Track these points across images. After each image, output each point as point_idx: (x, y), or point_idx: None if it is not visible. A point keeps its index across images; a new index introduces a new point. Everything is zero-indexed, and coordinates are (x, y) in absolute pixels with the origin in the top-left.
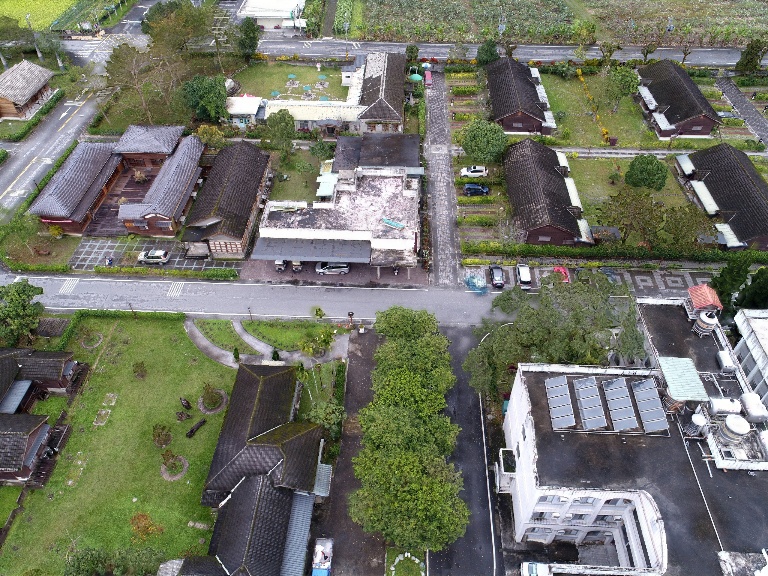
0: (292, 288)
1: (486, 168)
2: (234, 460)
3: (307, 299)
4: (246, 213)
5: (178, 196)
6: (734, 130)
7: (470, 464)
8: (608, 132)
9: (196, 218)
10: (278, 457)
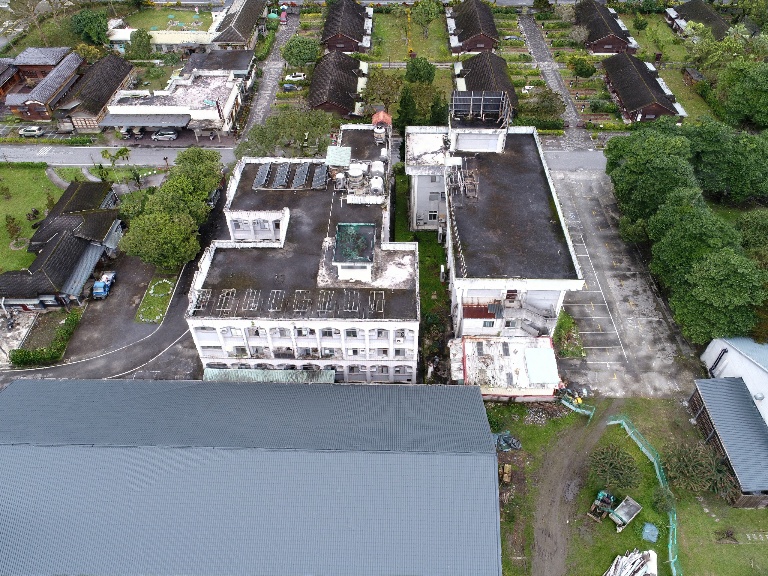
0: (132, 149)
1: (307, 76)
2: (51, 224)
3: (141, 155)
4: (103, 100)
5: (53, 90)
6: (516, 49)
7: (225, 238)
8: (414, 51)
9: (63, 102)
10: (80, 221)
